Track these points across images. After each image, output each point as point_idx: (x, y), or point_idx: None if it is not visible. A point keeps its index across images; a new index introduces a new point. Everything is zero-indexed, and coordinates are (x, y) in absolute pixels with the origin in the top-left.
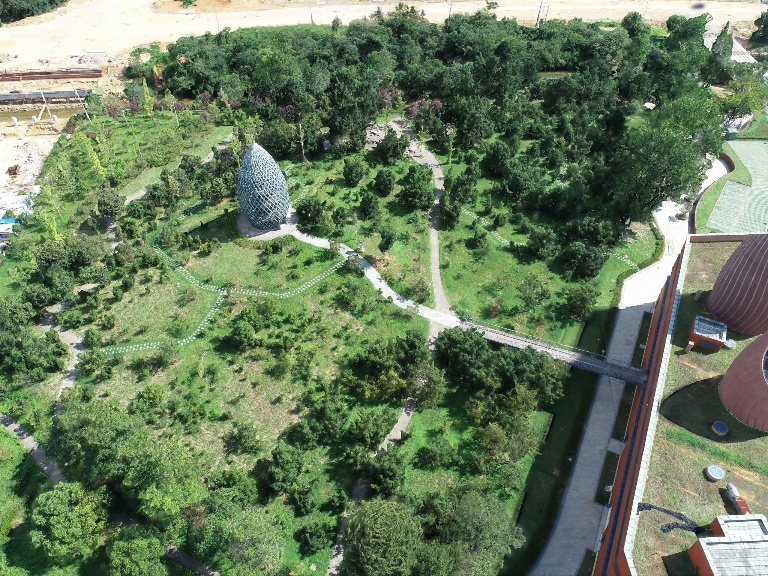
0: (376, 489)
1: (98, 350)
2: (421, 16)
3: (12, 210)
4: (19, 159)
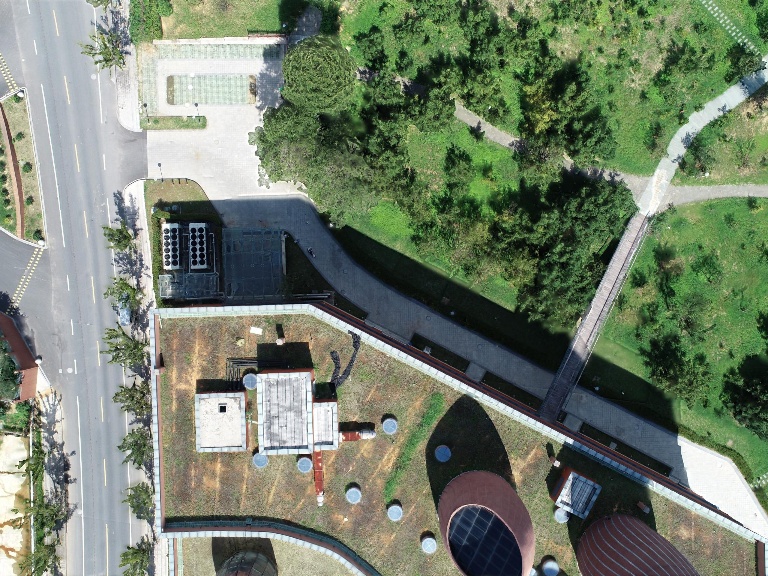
0: (413, 100)
1: None
2: None
3: None
4: None
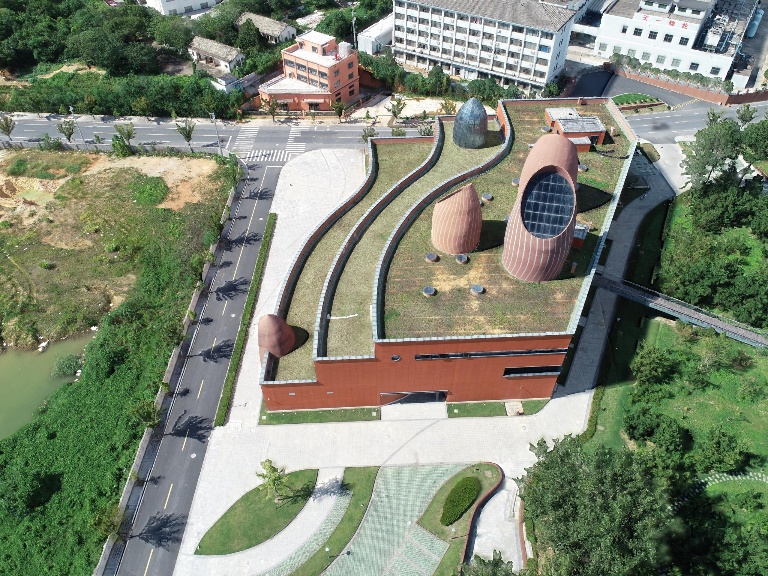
0: None
1: None
2: None
3: None
4: None
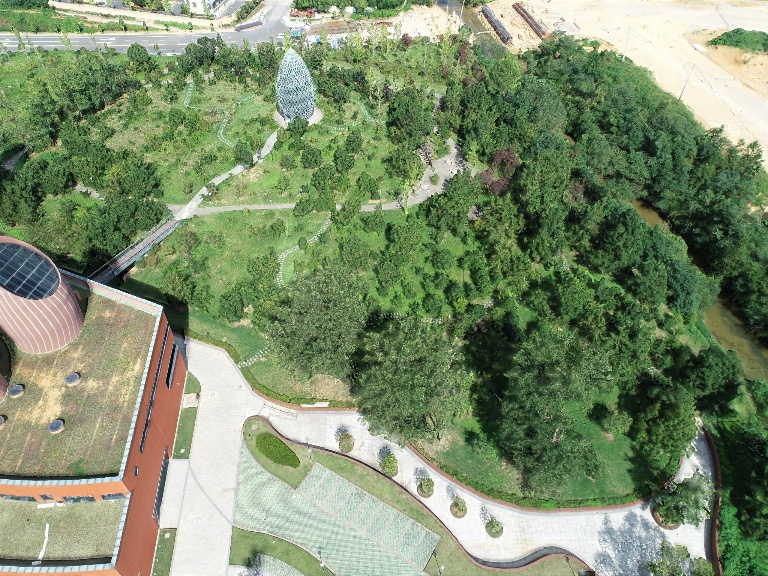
0: None
1: (182, 78)
2: (754, 171)
3: (330, 39)
4: (401, 33)
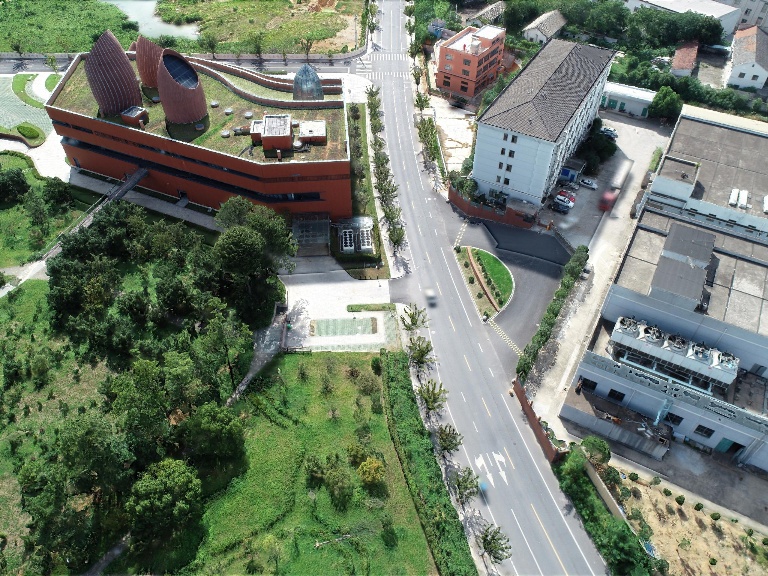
0: None
1: None
2: None
3: None
4: None
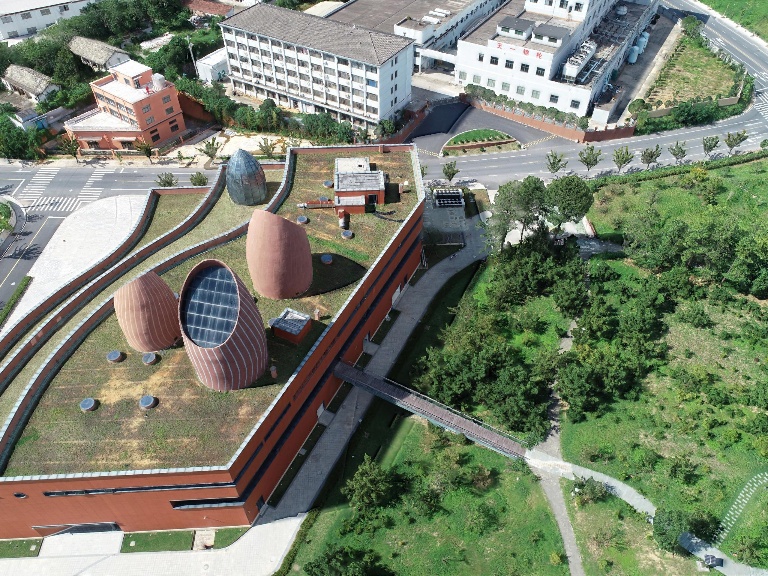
0: None
1: None
2: None
3: None
4: None
